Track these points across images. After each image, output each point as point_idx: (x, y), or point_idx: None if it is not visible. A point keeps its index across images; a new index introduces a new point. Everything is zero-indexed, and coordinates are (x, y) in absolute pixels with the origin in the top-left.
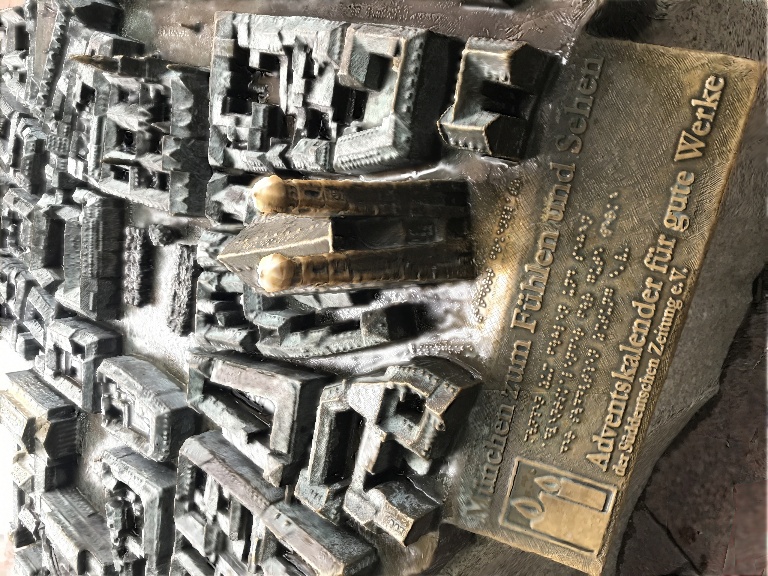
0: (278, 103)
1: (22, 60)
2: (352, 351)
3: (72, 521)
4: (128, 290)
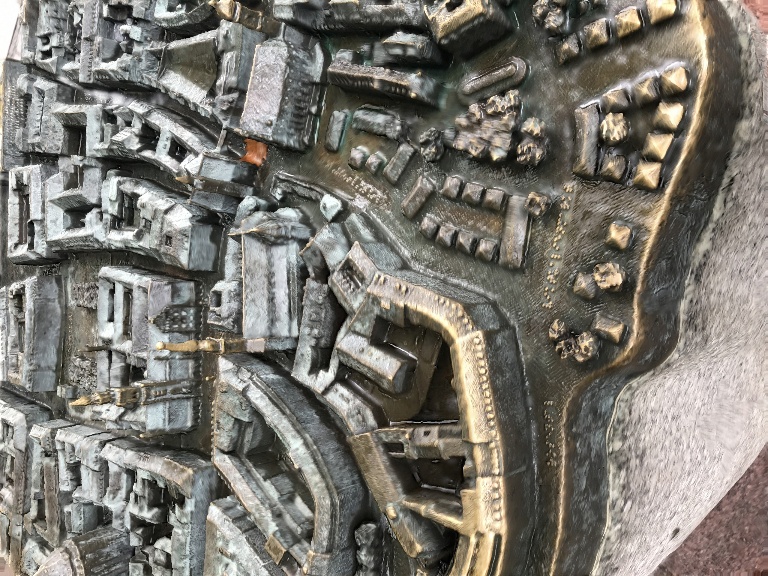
0: None
1: (180, 1)
2: None
3: None
4: None
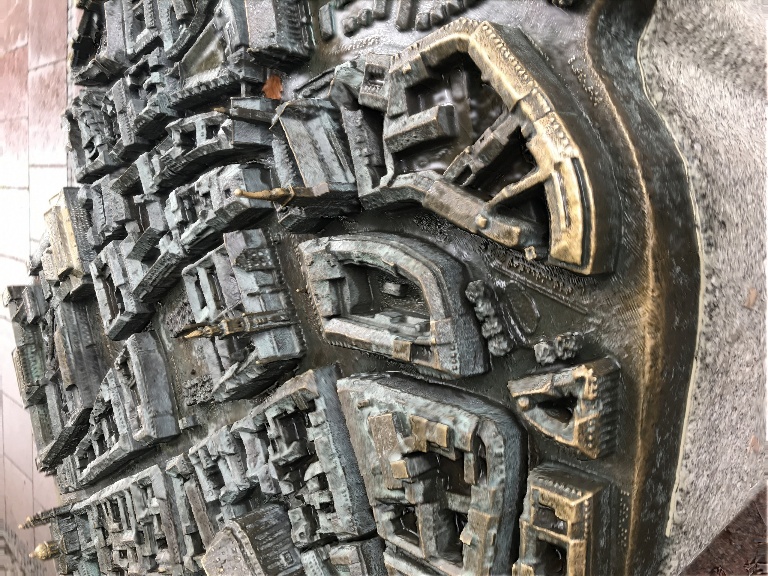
0: (310, 452)
1: None
2: None
3: (74, 349)
4: (171, 318)
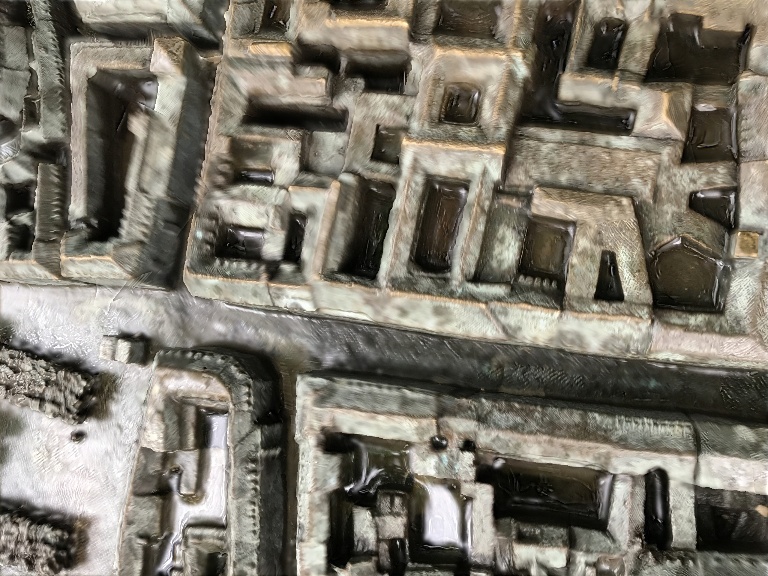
0: None
1: None
2: (74, 31)
3: None
4: (34, 564)
